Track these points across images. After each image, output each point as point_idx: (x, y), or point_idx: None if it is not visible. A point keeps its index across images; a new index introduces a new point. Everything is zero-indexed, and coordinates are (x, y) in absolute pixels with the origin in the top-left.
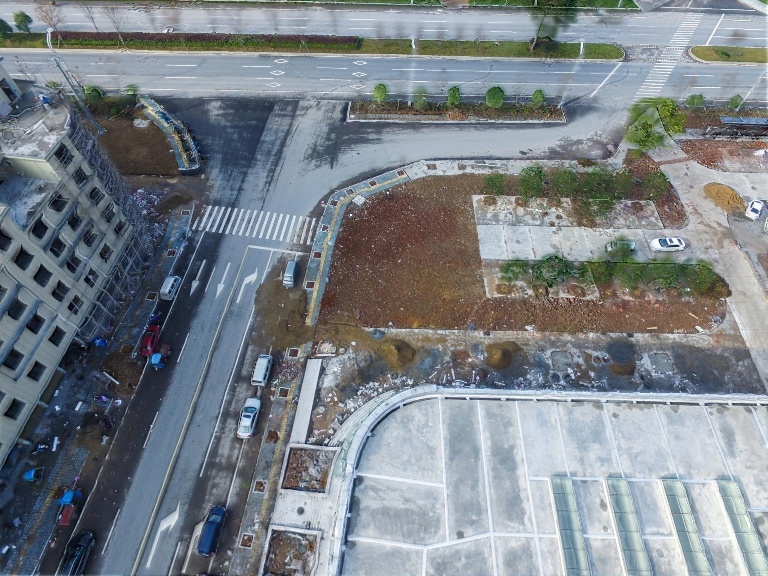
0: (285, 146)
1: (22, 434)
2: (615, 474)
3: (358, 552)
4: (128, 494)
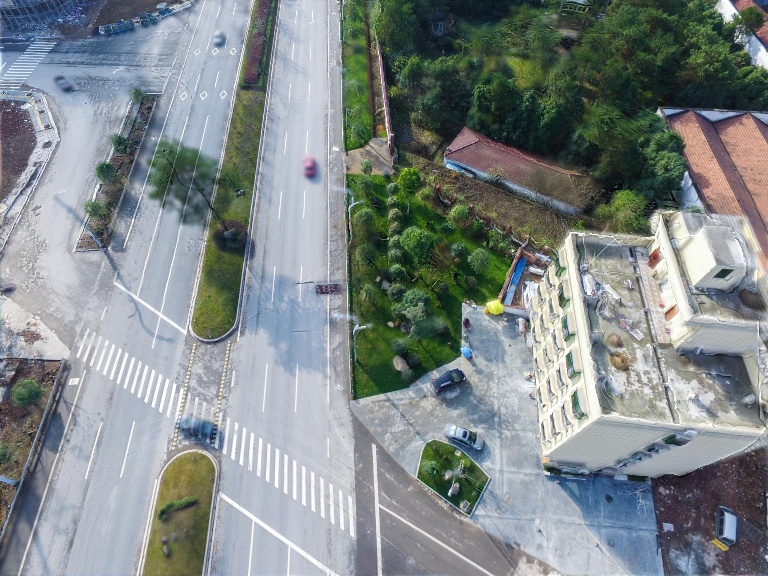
0: (110, 66)
1: None
2: None
3: None
4: None
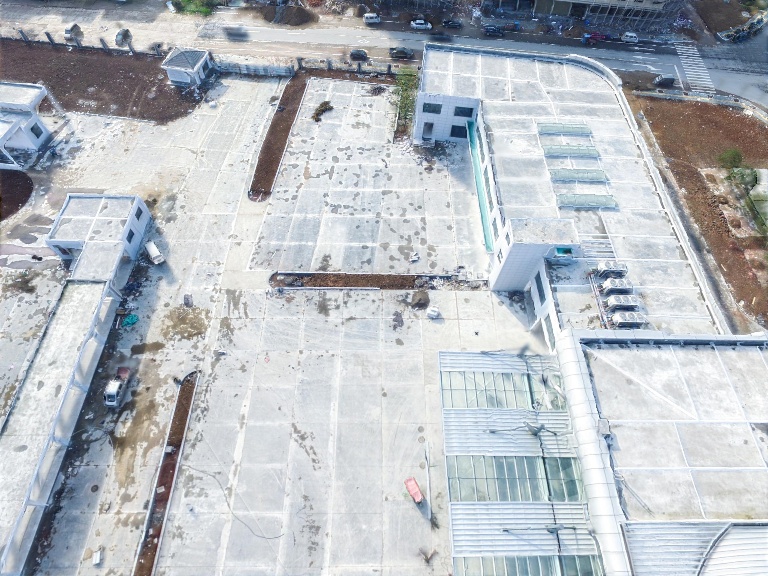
0: None
1: (538, 6)
2: (599, 154)
3: (531, 63)
4: (521, 42)
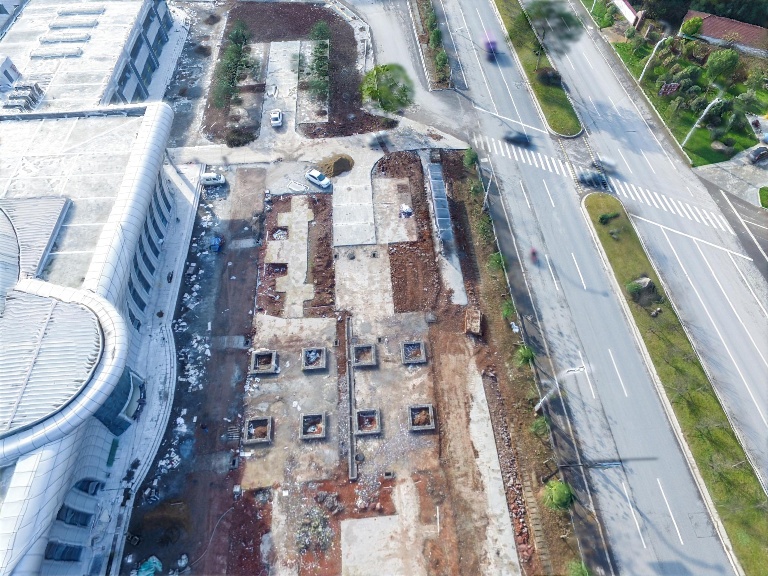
0: None
1: None
2: (98, 24)
3: None
4: None
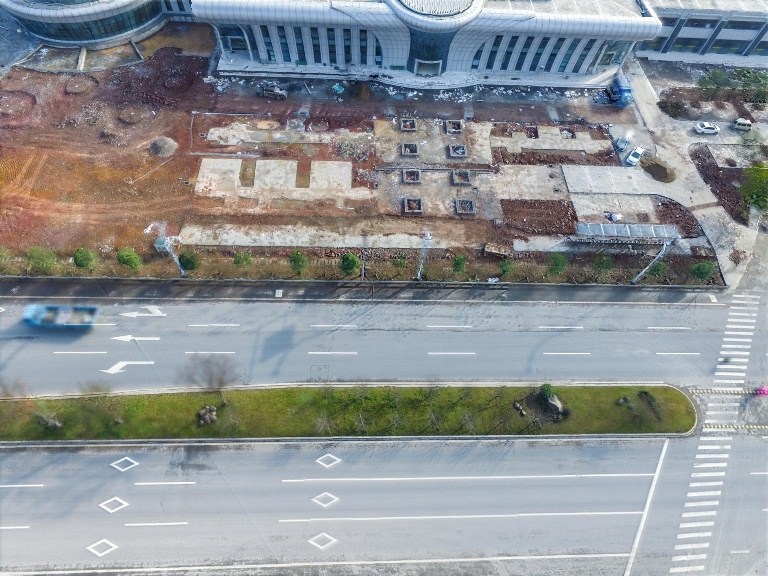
0: None
1: None
2: None
3: None
4: None
